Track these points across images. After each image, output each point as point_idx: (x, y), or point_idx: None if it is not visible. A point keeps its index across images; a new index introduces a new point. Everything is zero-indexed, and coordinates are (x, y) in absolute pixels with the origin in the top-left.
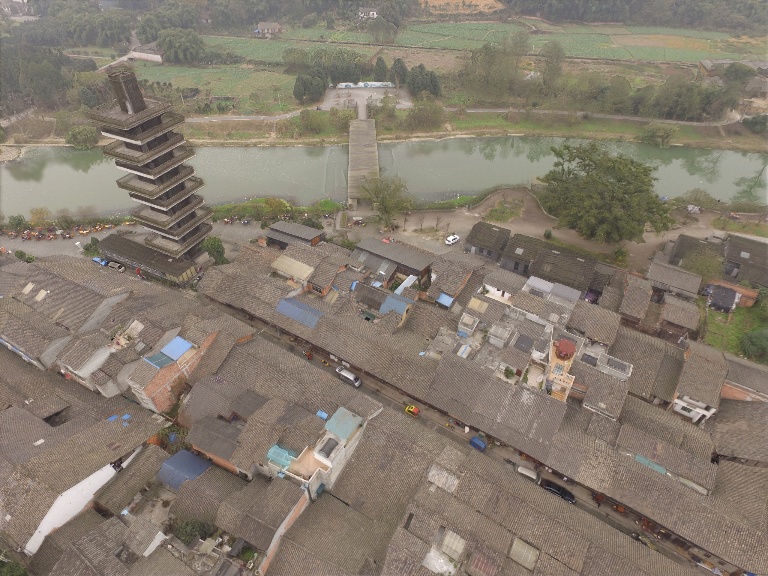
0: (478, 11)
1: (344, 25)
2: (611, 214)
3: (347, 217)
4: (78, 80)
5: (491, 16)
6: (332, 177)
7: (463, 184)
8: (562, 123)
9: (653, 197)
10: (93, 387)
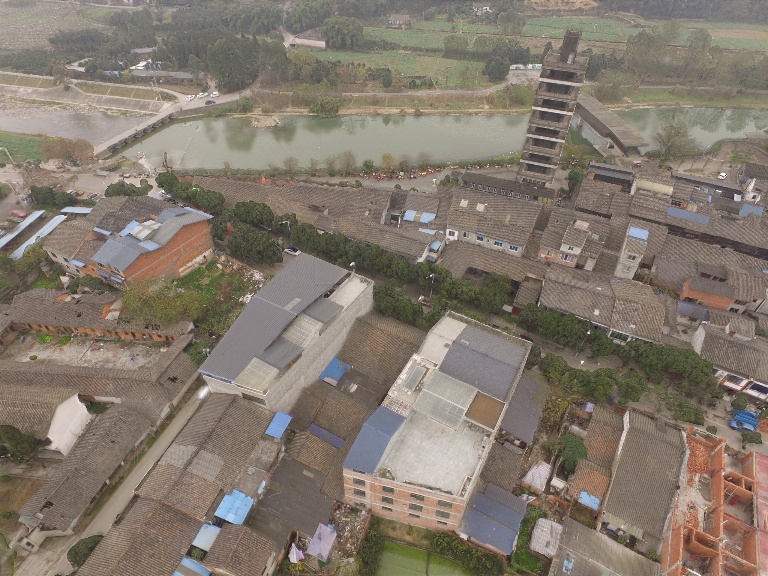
0: (577, 7)
1: (462, 18)
2: None
3: (625, 162)
4: (299, 59)
5: (589, 12)
6: None
7: None
8: (720, 97)
9: None
10: None
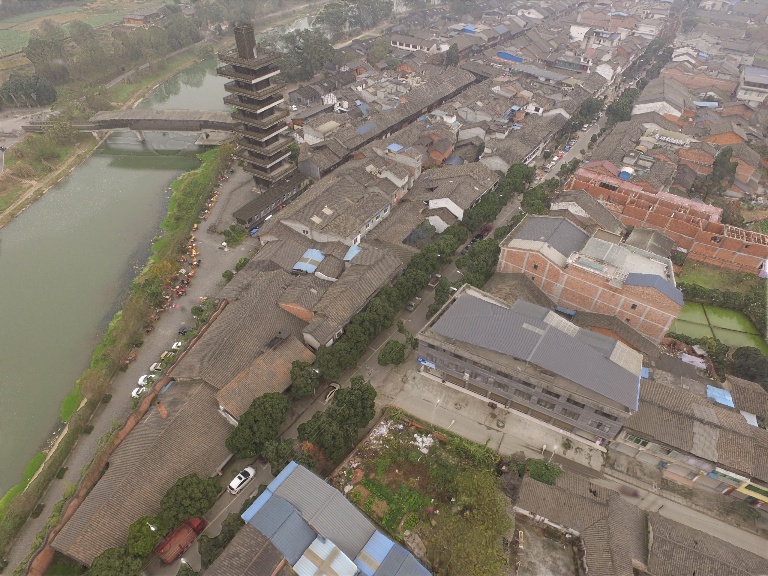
0: None
1: None
2: (328, 49)
3: None
4: None
5: None
6: (158, 154)
7: (215, 109)
8: (157, 70)
9: (324, 37)
10: (407, 190)
